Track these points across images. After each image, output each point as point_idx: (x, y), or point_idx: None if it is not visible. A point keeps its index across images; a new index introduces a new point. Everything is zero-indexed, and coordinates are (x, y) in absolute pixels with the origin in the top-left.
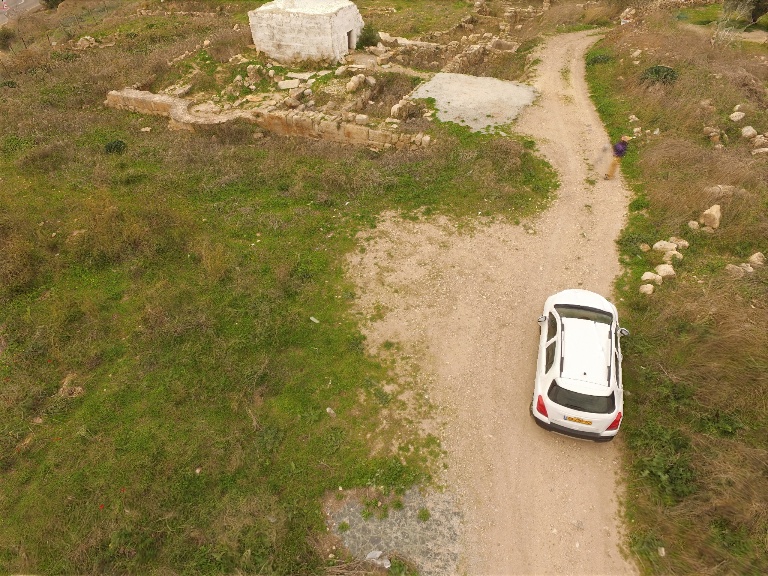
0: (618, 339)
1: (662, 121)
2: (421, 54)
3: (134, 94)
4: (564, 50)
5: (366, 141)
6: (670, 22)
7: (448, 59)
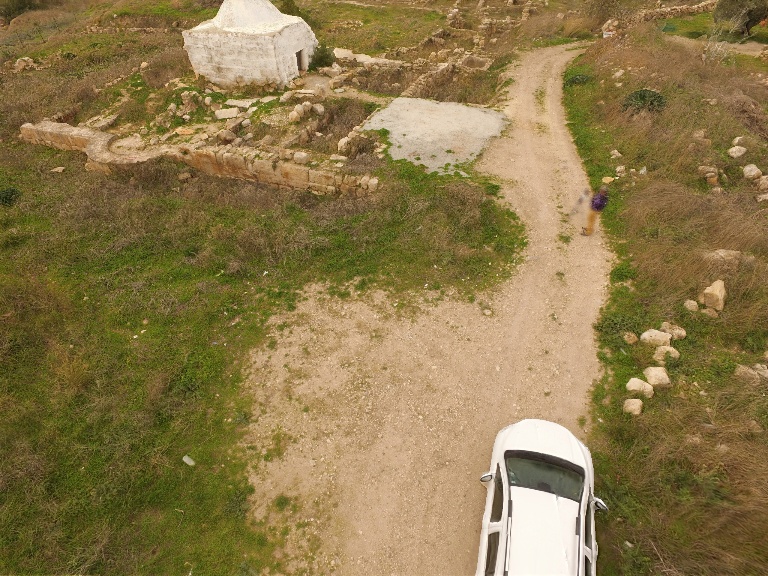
0: (592, 516)
1: (649, 158)
2: (382, 74)
3: (50, 127)
4: (540, 67)
5: (307, 183)
6: (656, 36)
7: (411, 80)
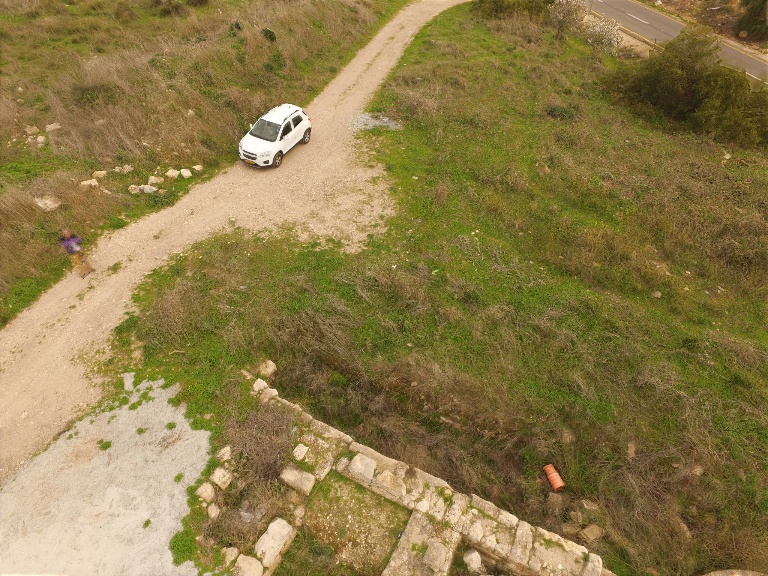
0: None
1: None
2: None
3: None
4: None
5: None
6: None
7: None
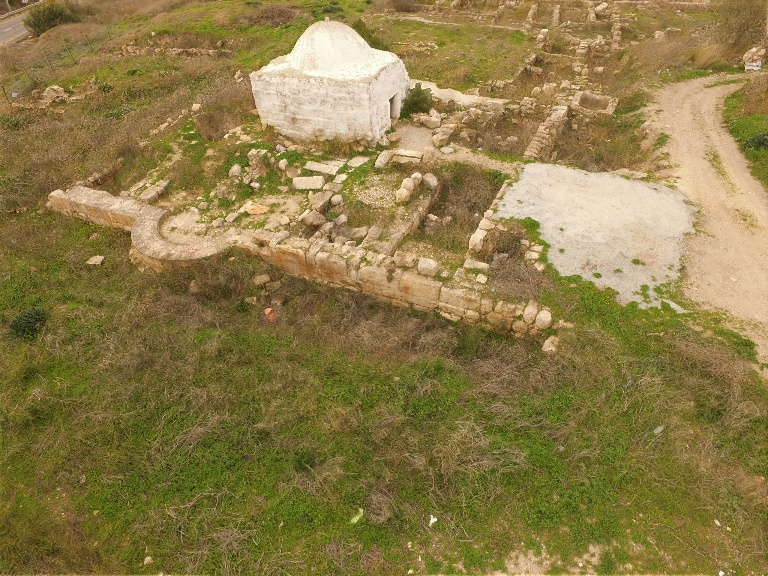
0: None
1: None
2: (489, 122)
3: (85, 197)
4: (688, 114)
5: (435, 302)
6: None
7: (531, 133)
